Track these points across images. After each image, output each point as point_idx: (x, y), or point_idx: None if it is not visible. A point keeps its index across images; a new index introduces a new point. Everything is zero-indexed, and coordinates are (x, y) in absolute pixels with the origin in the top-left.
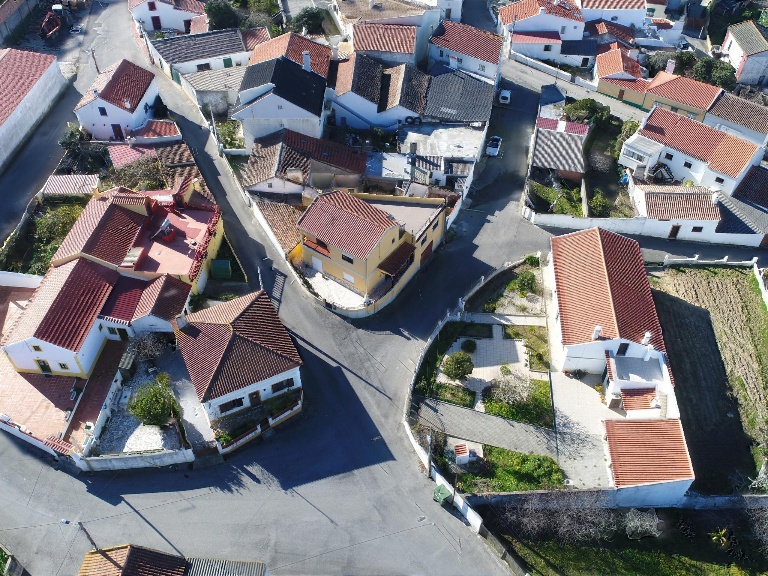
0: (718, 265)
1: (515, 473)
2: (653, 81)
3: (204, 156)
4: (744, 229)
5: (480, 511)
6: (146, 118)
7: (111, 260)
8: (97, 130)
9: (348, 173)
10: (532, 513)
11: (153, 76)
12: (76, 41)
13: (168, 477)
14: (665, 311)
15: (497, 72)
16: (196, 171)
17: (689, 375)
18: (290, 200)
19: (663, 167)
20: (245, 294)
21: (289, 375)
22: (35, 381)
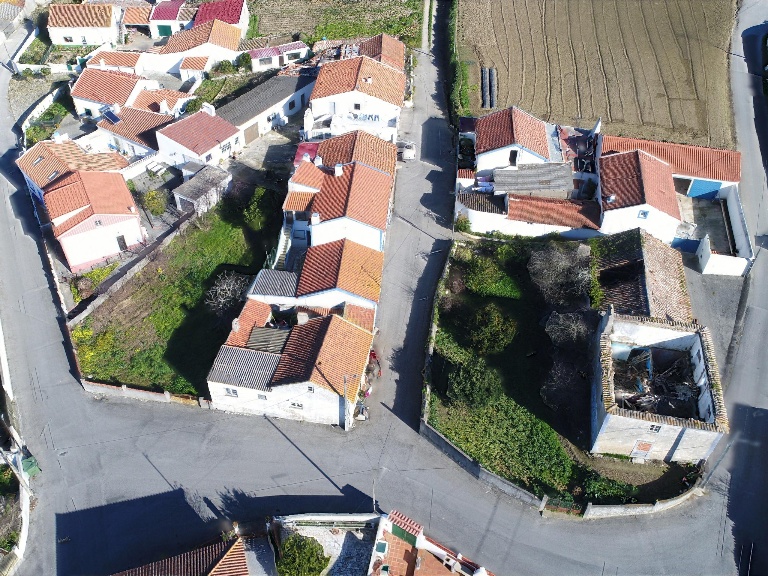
0: None
1: None
2: None
3: None
4: None
5: (6, 444)
6: None
7: None
8: None
9: None
10: None
11: None
12: None
13: (298, 512)
14: None
15: None
16: None
17: None
18: None
19: None
20: None
21: None
22: None
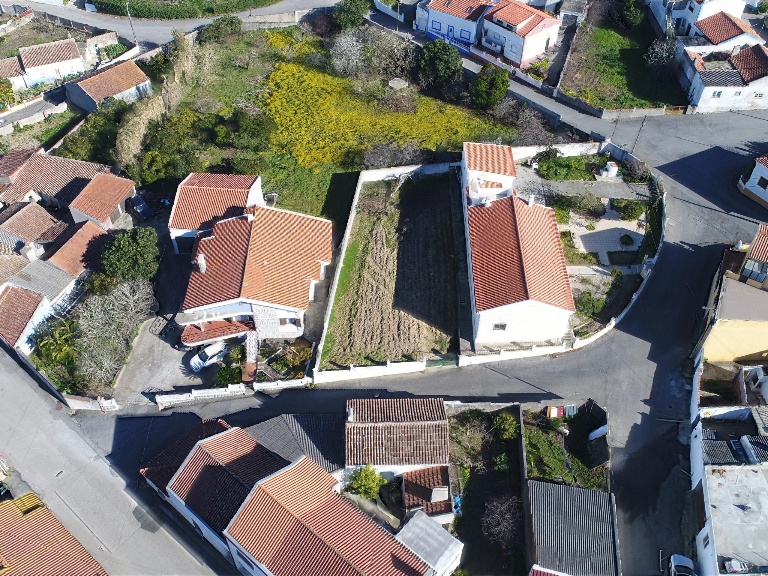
0: None
1: None
2: None
3: None
4: (308, 420)
5: None
6: None
7: None
8: None
9: None
10: None
11: None
12: None
13: None
14: (439, 302)
15: None
16: None
17: (432, 244)
18: None
19: None
20: None
21: None
22: None
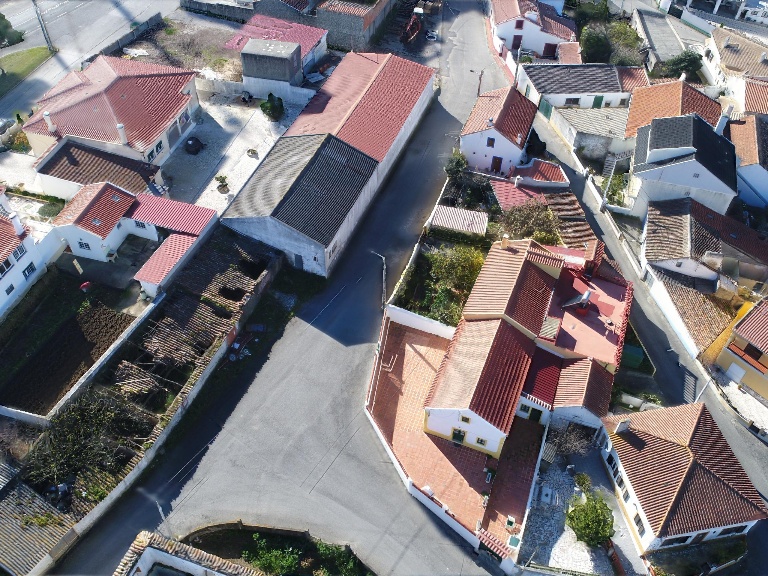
0: None
1: None
2: None
3: (583, 208)
4: None
5: None
6: (524, 153)
7: (530, 327)
8: (475, 159)
9: (756, 262)
10: None
11: (536, 108)
12: (434, 49)
13: None
14: None
15: None
16: (588, 229)
17: None
18: (699, 286)
19: None
20: (653, 391)
21: (746, 522)
22: (444, 448)
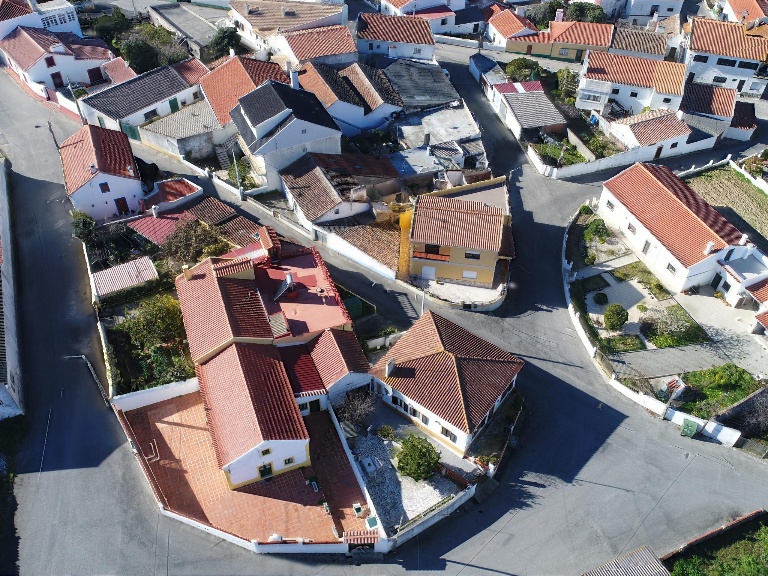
0: (707, 169)
1: (719, 387)
2: (552, 31)
3: None
4: (704, 135)
5: None
6: (141, 183)
7: (262, 335)
8: (97, 211)
9: (386, 180)
10: (764, 411)
11: (126, 136)
12: None
13: (466, 521)
14: None
15: (433, 52)
16: (246, 221)
17: None
18: (361, 221)
19: (614, 102)
20: (384, 324)
21: None
22: (259, 491)
